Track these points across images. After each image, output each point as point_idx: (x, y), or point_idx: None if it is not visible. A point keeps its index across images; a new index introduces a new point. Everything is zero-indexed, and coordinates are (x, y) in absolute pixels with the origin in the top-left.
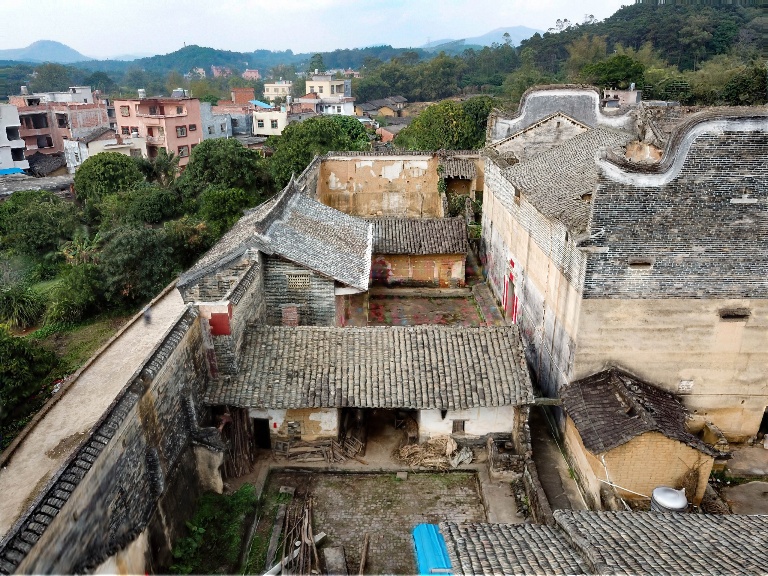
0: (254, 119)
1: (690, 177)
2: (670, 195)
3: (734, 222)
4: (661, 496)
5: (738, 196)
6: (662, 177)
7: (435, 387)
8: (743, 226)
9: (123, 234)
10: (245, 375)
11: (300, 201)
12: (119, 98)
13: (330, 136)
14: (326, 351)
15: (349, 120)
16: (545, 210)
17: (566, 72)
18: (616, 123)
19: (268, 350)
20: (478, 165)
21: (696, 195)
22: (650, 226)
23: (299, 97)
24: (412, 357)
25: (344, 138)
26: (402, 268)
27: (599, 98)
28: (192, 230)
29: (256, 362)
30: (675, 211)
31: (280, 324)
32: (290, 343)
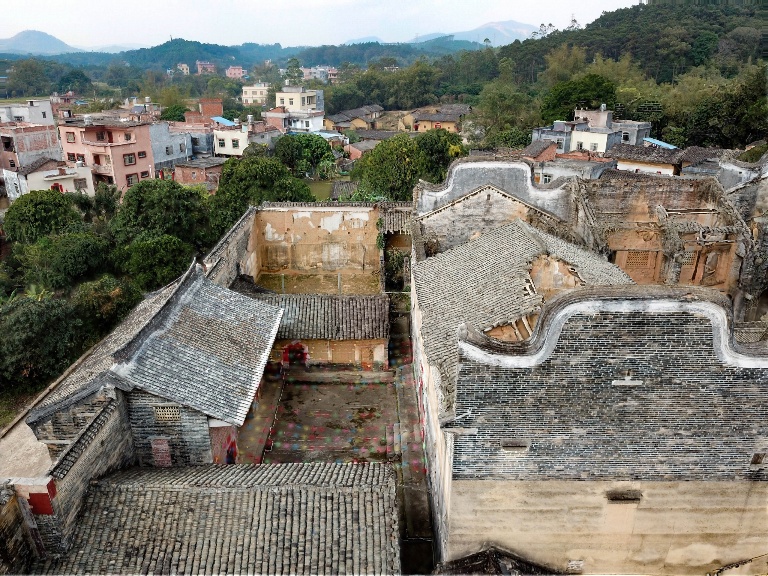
0: (215, 138)
1: (565, 358)
2: (543, 376)
3: (618, 404)
4: None
5: (620, 378)
6: (533, 358)
7: (291, 571)
8: (628, 408)
9: (22, 310)
10: (77, 553)
11: (199, 291)
12: (65, 123)
13: (271, 179)
14: (174, 520)
15: (314, 139)
16: (429, 352)
17: (538, 89)
18: (550, 196)
19: (109, 518)
20: None
21: (573, 376)
22: (523, 408)
23: (266, 111)
24: (271, 528)
25: (286, 181)
26: (321, 351)
27: (531, 171)
28: (106, 298)
29: (93, 535)
30: (550, 392)
31: (150, 456)
32: (136, 508)
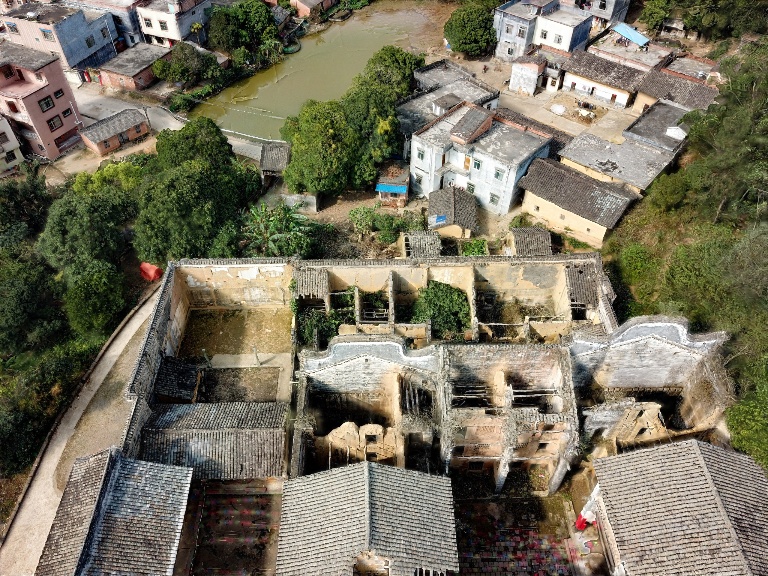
0: (140, 17)
1: None
2: None
3: None
4: None
5: None
6: None
7: None
8: None
9: None
10: None
11: (118, 481)
12: None
13: (190, 206)
14: None
15: (252, 10)
16: None
17: None
18: (421, 359)
19: None
20: (333, 272)
21: None
22: None
23: None
24: None
25: (205, 207)
26: None
27: (402, 347)
28: (48, 397)
29: None
30: None
31: None
32: None
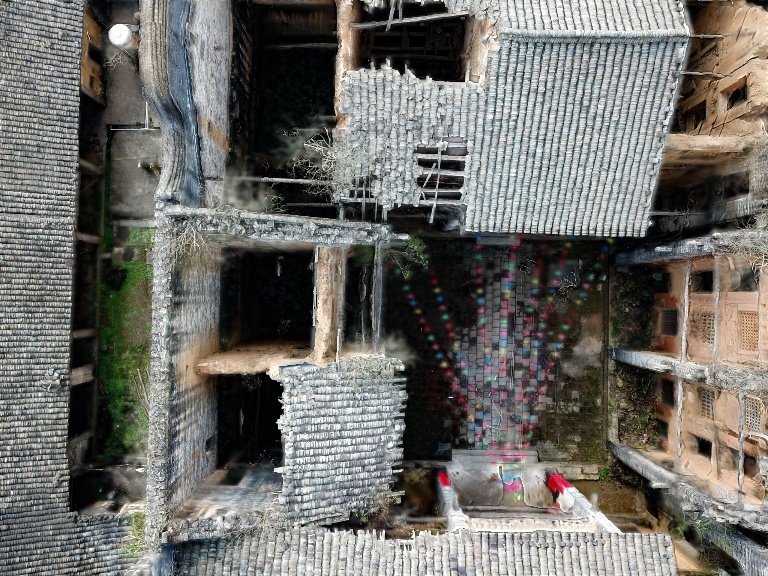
0: None
1: None
2: None
3: None
4: (116, 26)
5: None
6: None
7: None
8: None
9: None
10: None
11: None
12: None
13: None
14: None
15: None
16: None
17: None
18: None
19: None
20: None
21: None
22: None
23: None
24: None
25: None
26: None
27: None
28: None
29: None
30: None
31: None
32: None
